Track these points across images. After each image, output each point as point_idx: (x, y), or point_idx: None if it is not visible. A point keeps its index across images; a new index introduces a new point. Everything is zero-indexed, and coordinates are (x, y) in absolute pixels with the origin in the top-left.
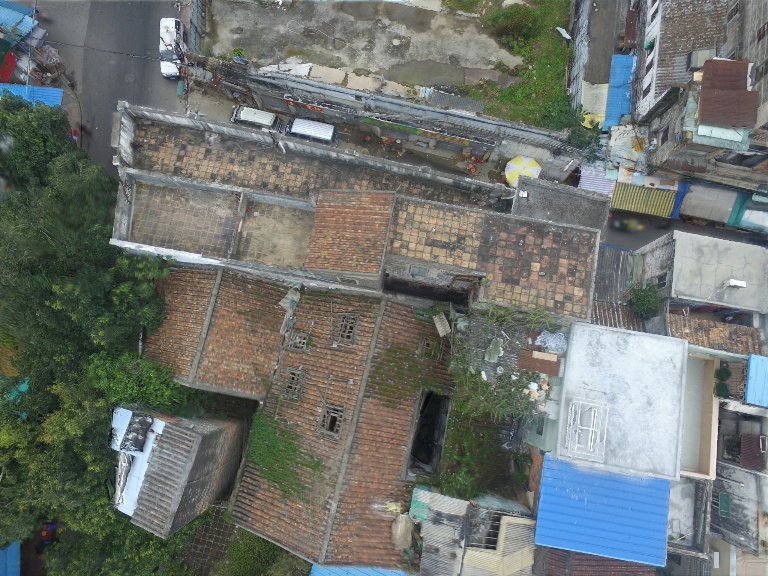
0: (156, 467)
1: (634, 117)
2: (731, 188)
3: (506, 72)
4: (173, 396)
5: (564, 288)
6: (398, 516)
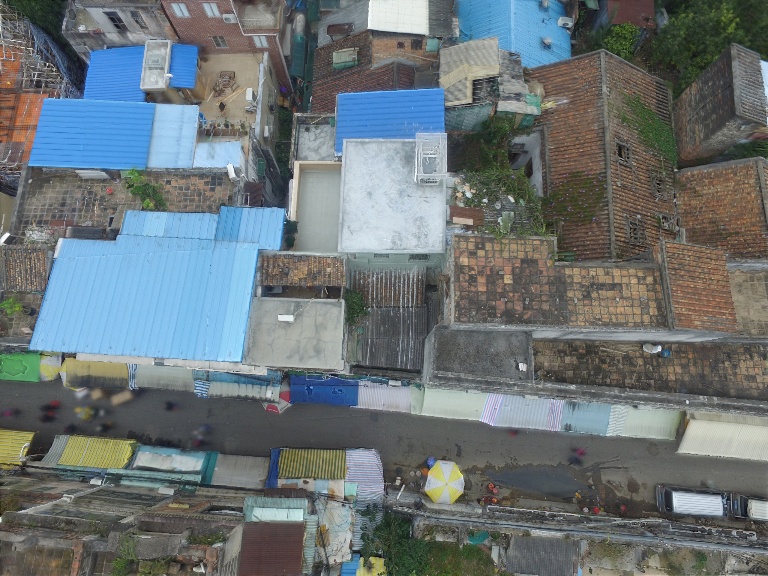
0: (760, 92)
1: (327, 575)
2: (225, 486)
3: None
4: (767, 151)
5: (478, 263)
6: (541, 101)
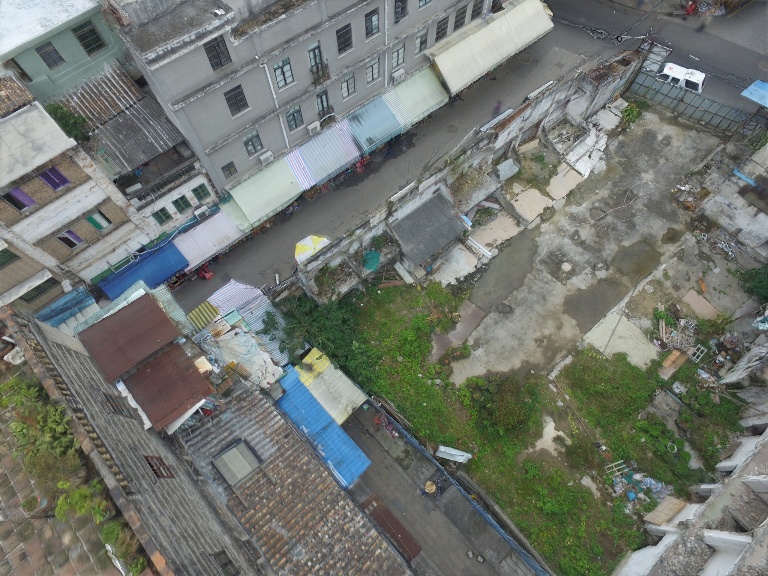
0: None
1: (270, 400)
2: None
3: (452, 352)
4: None
5: None
6: None
